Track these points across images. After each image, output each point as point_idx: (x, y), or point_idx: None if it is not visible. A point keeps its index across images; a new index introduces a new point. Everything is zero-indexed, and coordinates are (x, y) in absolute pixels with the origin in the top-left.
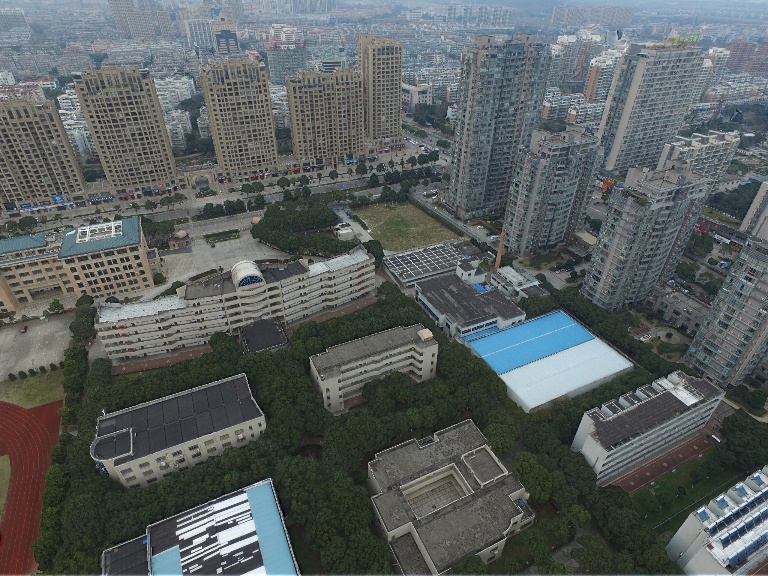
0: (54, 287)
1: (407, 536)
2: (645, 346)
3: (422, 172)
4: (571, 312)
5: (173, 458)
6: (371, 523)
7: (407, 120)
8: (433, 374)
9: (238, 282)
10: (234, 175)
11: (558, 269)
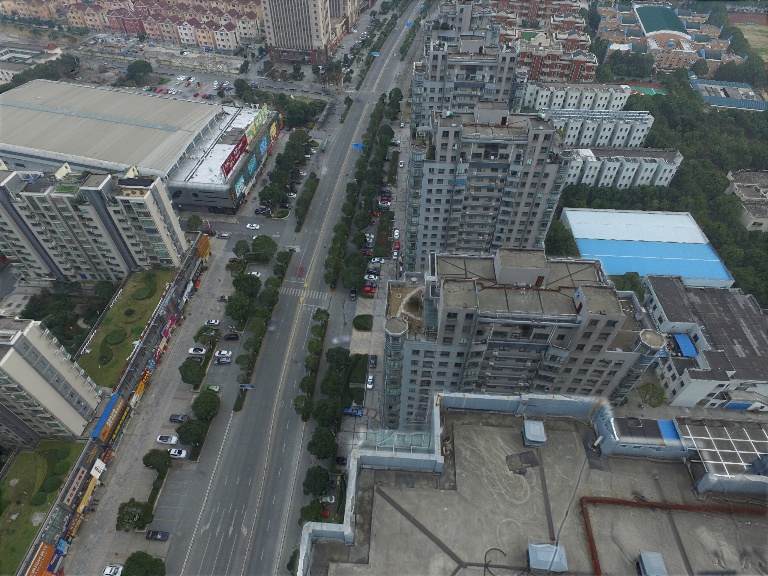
0: None
1: None
2: None
3: None
4: None
5: None
6: None
7: None
8: None
9: None
10: None
11: None
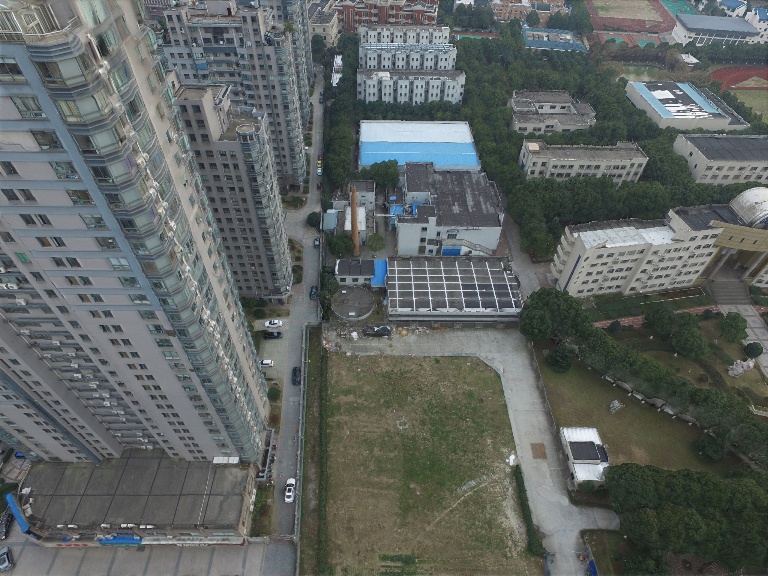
0: None
1: None
2: None
3: None
4: None
5: None
6: None
7: None
8: None
9: None
10: None
11: None
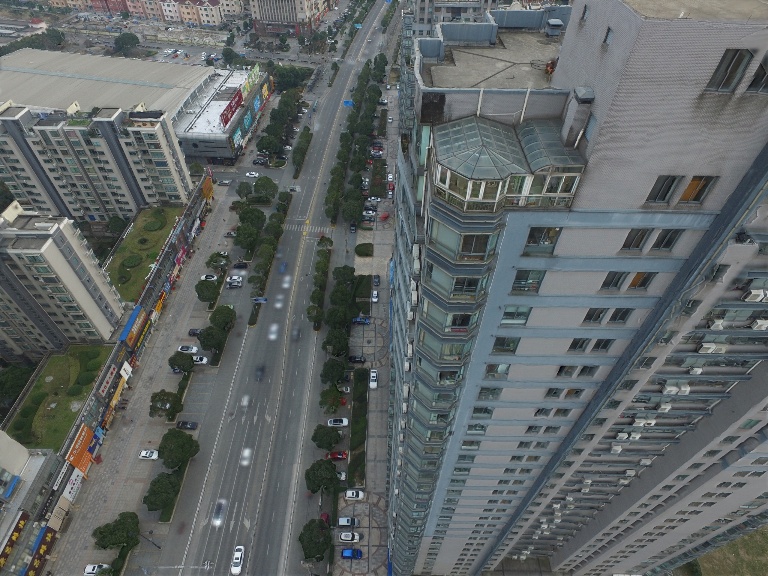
0: None
1: None
2: None
3: None
4: None
5: None
6: None
7: None
8: None
9: None
10: None
11: None
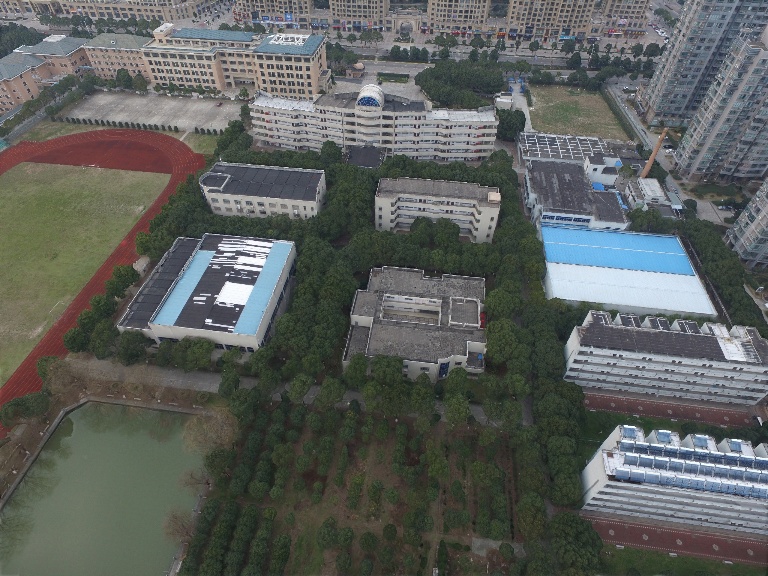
0: (252, 82)
1: (368, 329)
2: (750, 302)
3: (640, 64)
4: (693, 245)
5: (246, 206)
6: (346, 306)
7: (675, 7)
8: (489, 241)
9: (358, 100)
10: (437, 27)
11: (724, 204)
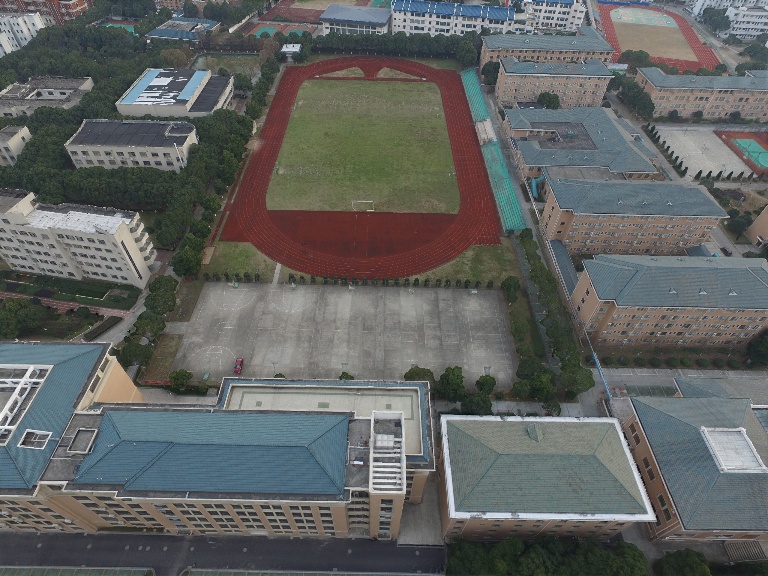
0: None
1: None
2: None
3: None
4: None
5: None
6: None
7: None
8: None
9: None
10: None
11: None
